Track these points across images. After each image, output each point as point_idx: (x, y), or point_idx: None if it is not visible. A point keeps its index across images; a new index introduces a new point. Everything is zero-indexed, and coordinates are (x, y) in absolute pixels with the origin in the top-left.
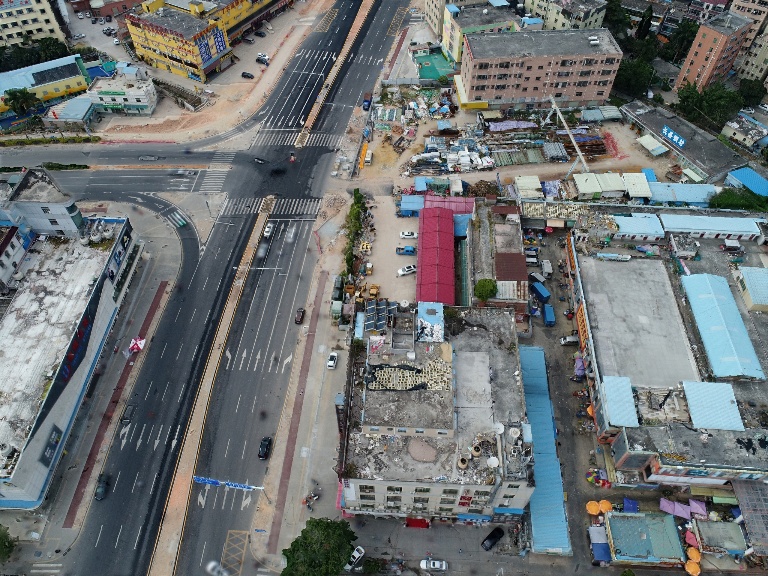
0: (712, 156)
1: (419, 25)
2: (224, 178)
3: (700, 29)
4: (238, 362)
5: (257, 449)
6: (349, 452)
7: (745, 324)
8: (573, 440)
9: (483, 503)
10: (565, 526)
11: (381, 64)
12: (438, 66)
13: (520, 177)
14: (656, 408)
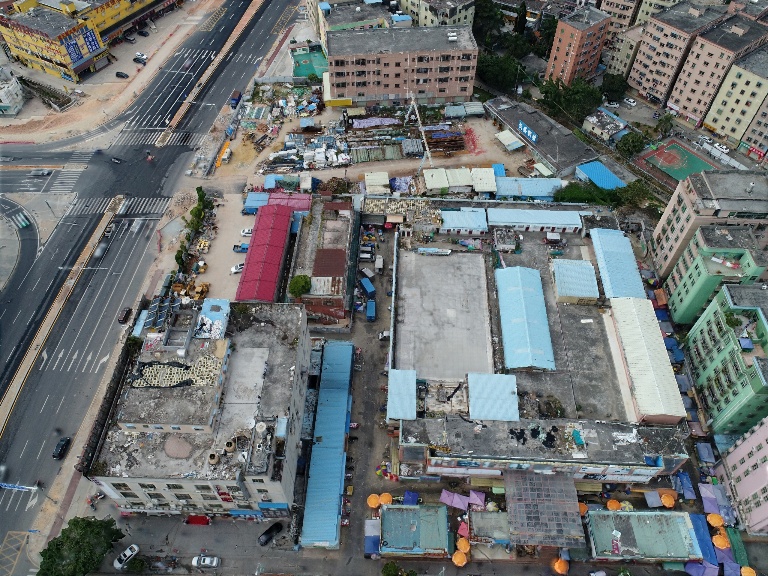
0: (564, 150)
1: (304, 23)
2: (77, 178)
3: (558, 25)
4: (53, 362)
5: (54, 449)
6: (103, 450)
7: (551, 316)
8: (372, 434)
9: (242, 498)
10: (336, 519)
11: (259, 62)
12: (316, 64)
13: (370, 173)
14: (442, 400)
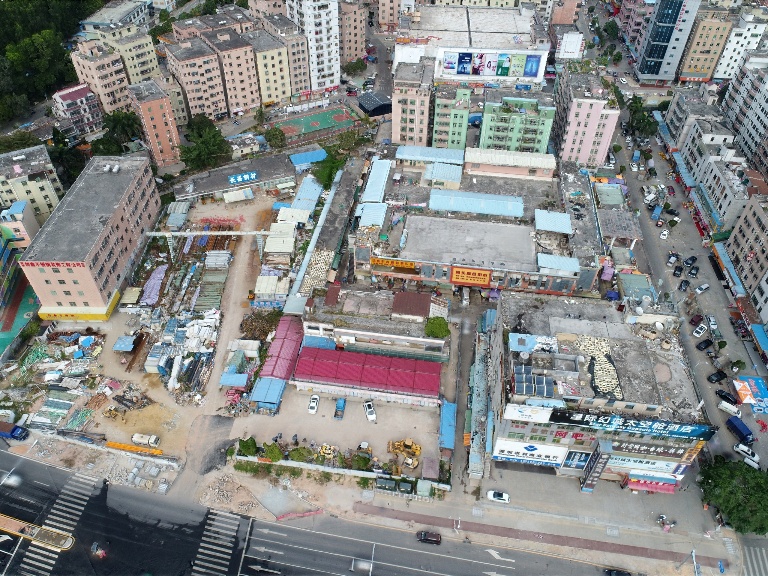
0: (271, 168)
1: None
2: None
3: (142, 107)
4: None
5: None
6: None
7: None
8: None
9: None
10: None
11: None
12: None
13: (256, 289)
14: (552, 251)
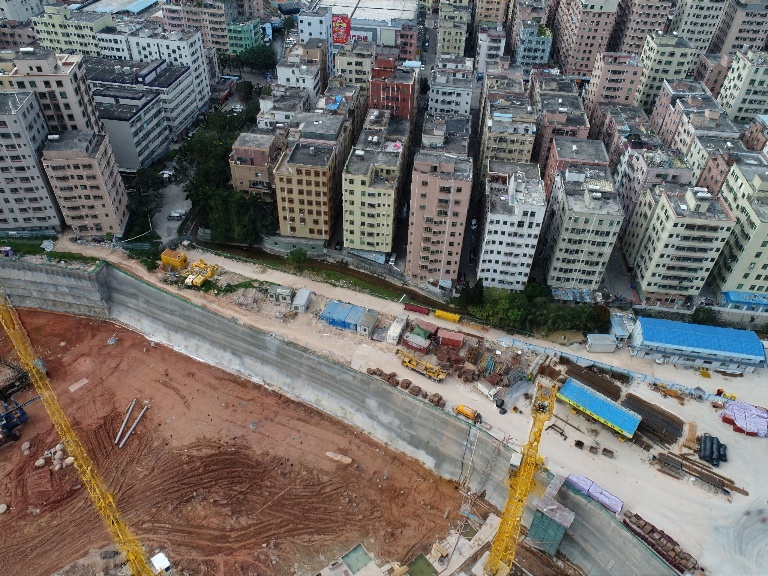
0: None
1: None
2: None
3: None
4: None
5: None
6: None
7: (153, 8)
8: None
9: None
10: None
11: None
12: None
13: None
14: None
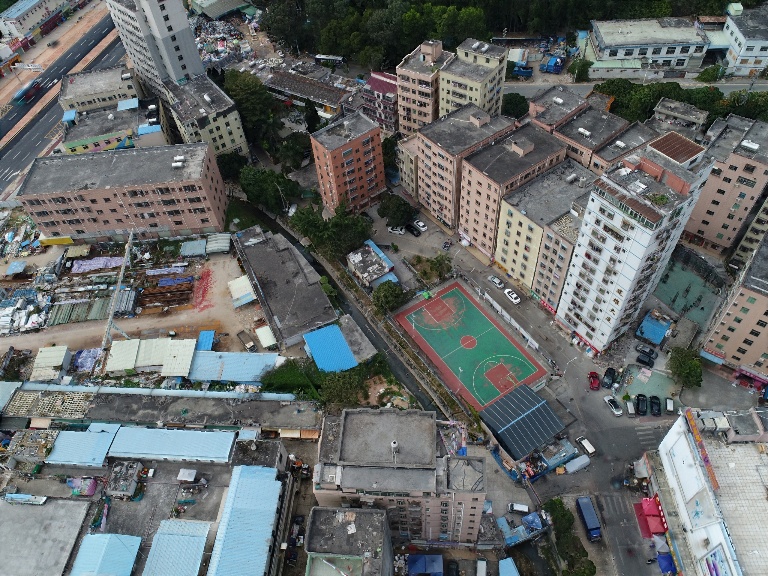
0: (299, 308)
1: None
2: None
3: None
4: None
5: None
6: None
7: None
8: None
9: None
10: None
11: (12, 179)
12: None
13: (45, 349)
14: None
